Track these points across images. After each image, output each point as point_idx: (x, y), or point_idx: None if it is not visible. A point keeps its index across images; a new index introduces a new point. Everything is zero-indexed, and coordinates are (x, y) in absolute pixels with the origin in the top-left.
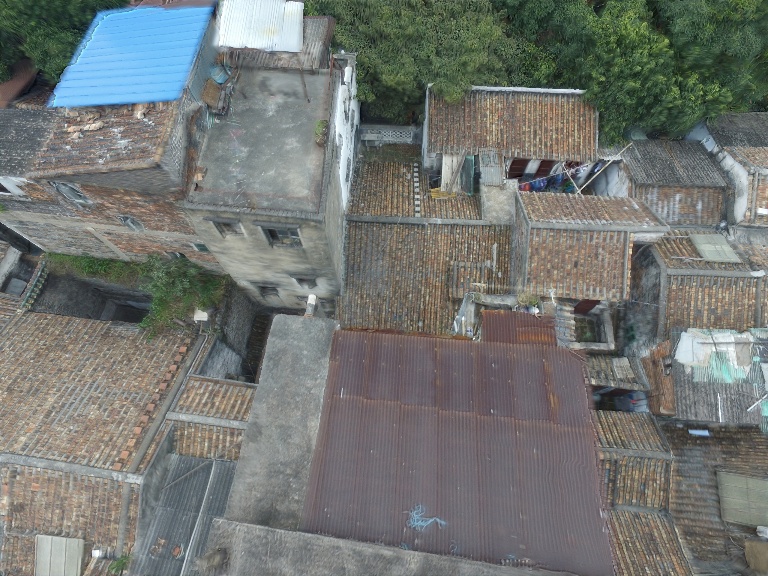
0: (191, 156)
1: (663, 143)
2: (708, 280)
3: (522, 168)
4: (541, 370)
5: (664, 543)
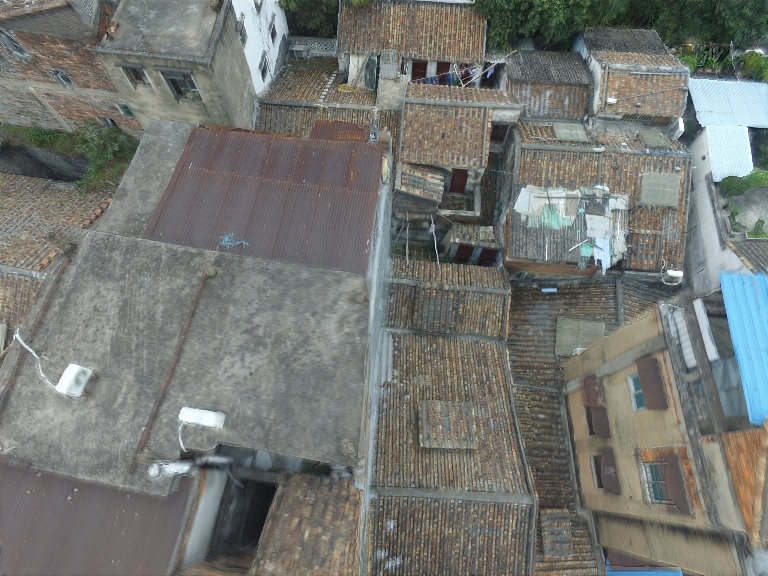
0: (104, 10)
1: (546, 53)
2: (557, 155)
3: (423, 72)
4: (349, 157)
5: (494, 360)
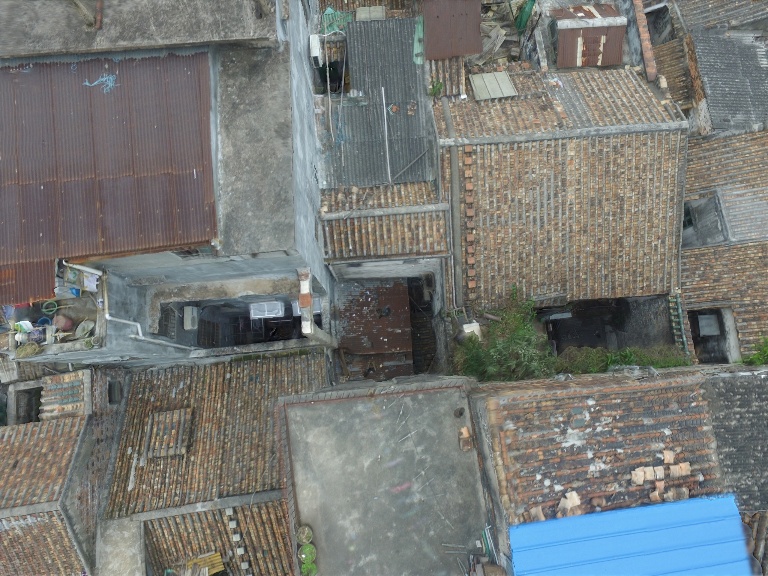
0: (480, 454)
1: None
2: None
3: None
4: None
5: None
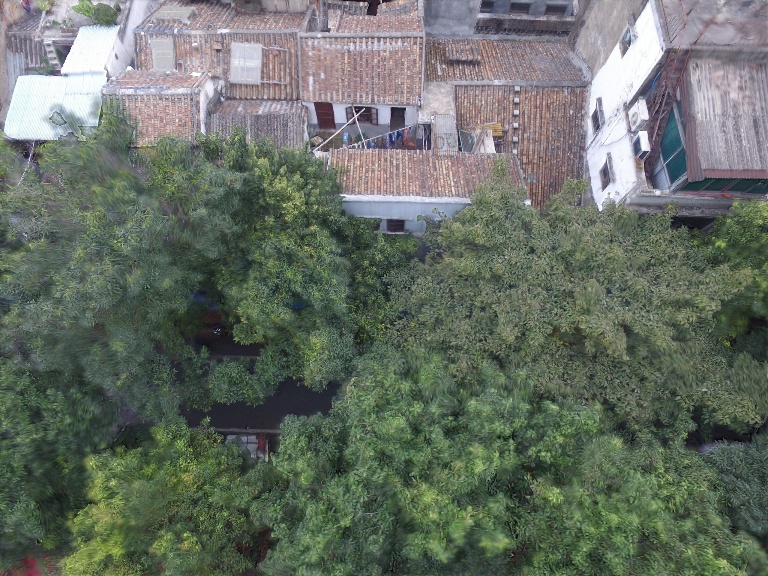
0: None
1: None
2: None
3: None
4: None
5: None
